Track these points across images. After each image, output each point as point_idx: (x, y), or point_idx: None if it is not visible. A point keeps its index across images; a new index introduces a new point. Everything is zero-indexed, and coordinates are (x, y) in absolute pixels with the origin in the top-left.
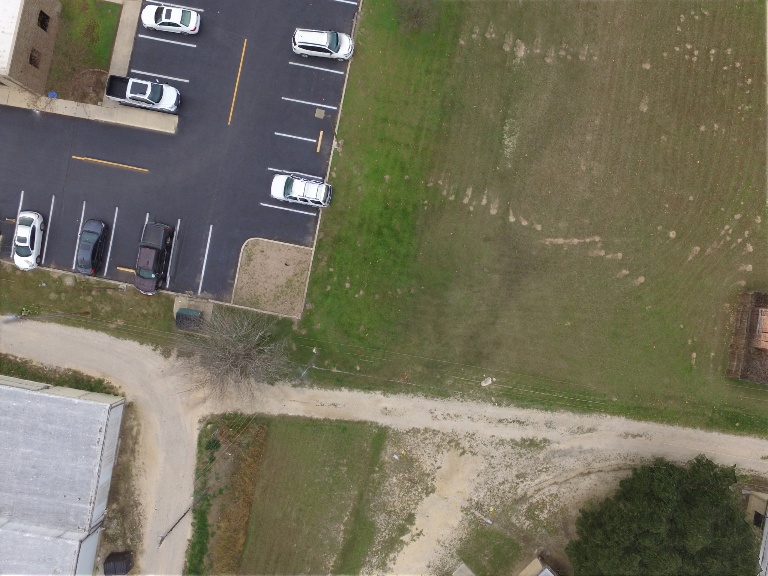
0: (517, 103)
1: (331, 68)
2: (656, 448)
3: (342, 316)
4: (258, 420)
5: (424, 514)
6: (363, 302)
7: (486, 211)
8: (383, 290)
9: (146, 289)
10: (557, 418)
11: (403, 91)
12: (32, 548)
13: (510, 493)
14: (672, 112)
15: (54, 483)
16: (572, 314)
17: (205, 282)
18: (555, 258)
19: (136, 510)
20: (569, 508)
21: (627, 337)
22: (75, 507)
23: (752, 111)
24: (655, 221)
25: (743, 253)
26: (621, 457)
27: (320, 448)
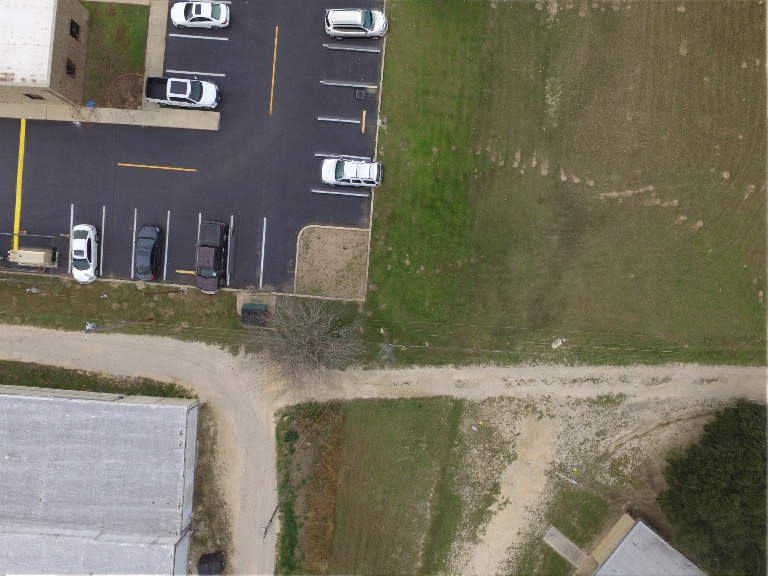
0: (556, 61)
1: (366, 48)
2: (733, 390)
3: (406, 294)
4: (333, 407)
5: (508, 482)
6: (425, 278)
7: (537, 173)
8: (443, 263)
9: (209, 288)
10: (631, 372)
11: (441, 62)
12: (128, 557)
13: (592, 451)
14: (712, 53)
15: (141, 491)
16: (635, 266)
17: (265, 275)
18: (611, 212)
19: (222, 510)
20: (652, 460)
21: (692, 283)
22: (165, 512)
23: None
24: (707, 164)
25: None
26: (699, 403)
27: (398, 428)
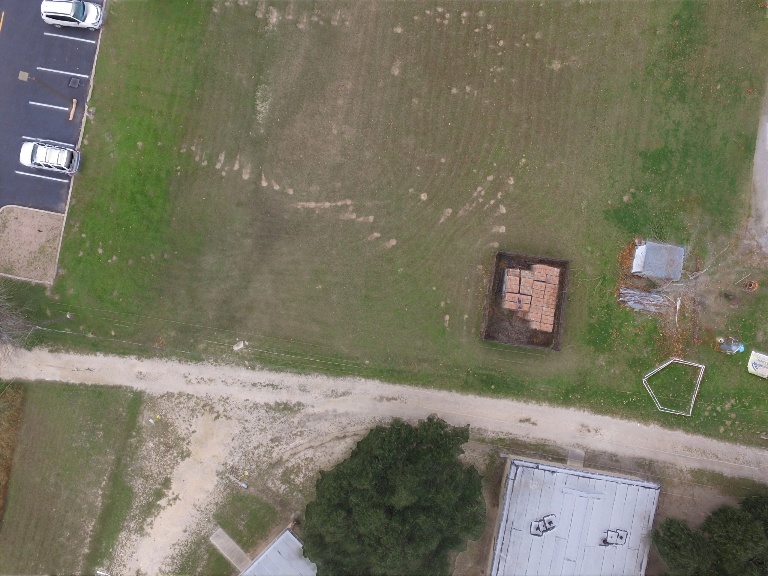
0: (269, 69)
1: (86, 38)
2: (411, 411)
3: (95, 281)
4: (15, 385)
5: (180, 478)
6: (116, 267)
7: (238, 176)
8: (136, 255)
9: None
10: (311, 381)
11: (155, 59)
12: None
13: (265, 457)
14: (423, 75)
15: None
16: (323, 277)
17: None
18: (307, 222)
19: None
20: None
21: (379, 300)
22: None
23: (504, 73)
24: (406, 183)
25: (496, 214)
26: (376, 420)
27: (76, 413)
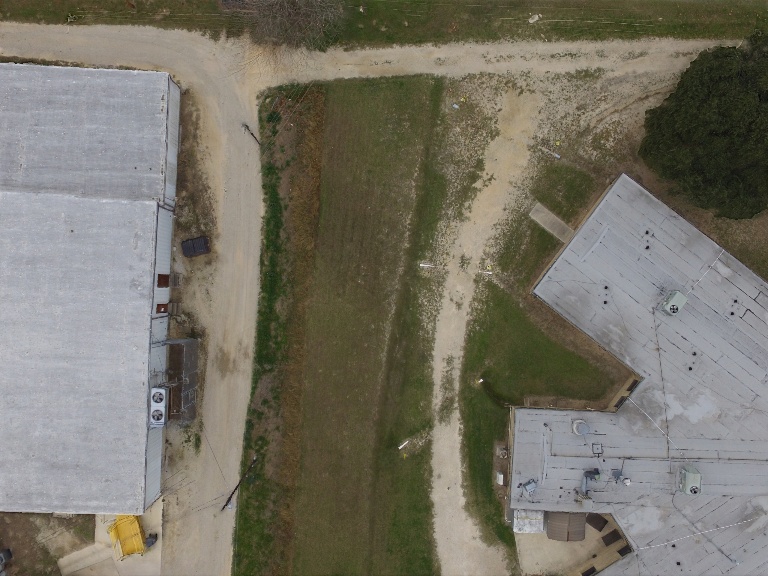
0: None
1: None
2: None
3: None
4: (315, 87)
5: (492, 158)
6: None
7: None
8: None
9: None
10: (607, 46)
11: None
12: (110, 213)
13: (573, 126)
14: None
15: (123, 156)
16: None
17: None
18: None
19: (206, 194)
20: (633, 133)
21: None
22: (147, 178)
23: None
24: None
25: None
26: (676, 76)
27: (380, 106)
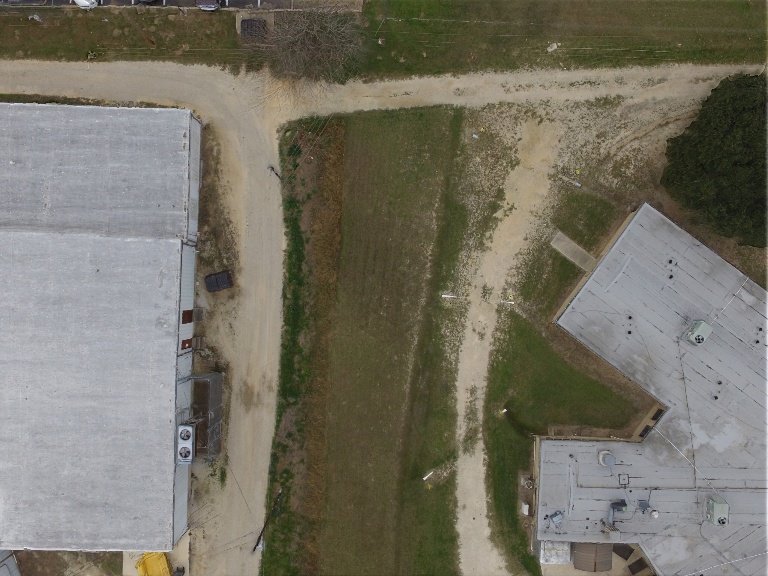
0: None
1: None
2: None
3: (401, 5)
4: (335, 120)
5: (513, 188)
6: None
7: None
8: None
9: (208, 3)
10: (626, 74)
11: None
12: (135, 252)
13: (593, 154)
14: None
15: (146, 194)
16: None
17: None
18: None
19: (228, 228)
20: (654, 160)
21: None
22: (170, 215)
23: None
24: None
25: None
26: (696, 102)
27: (400, 138)
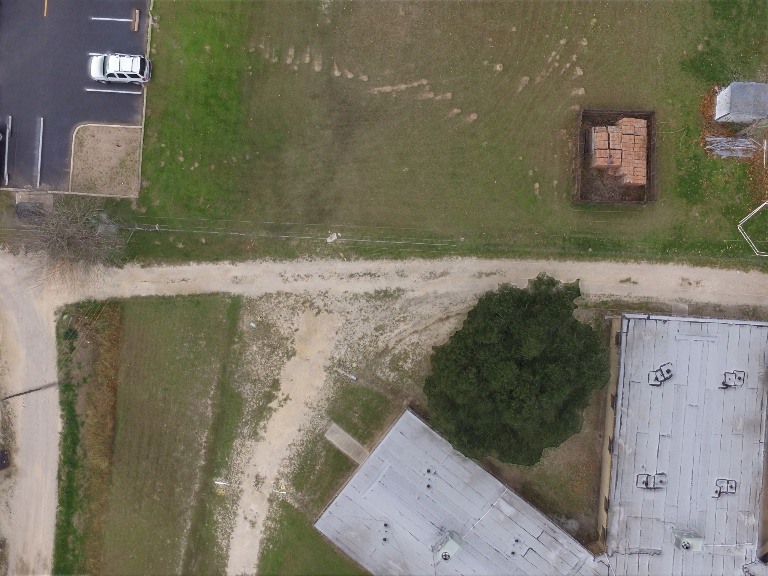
0: None
1: None
2: None
3: (180, 190)
4: (112, 305)
5: (288, 378)
6: (199, 174)
7: (311, 69)
8: (218, 160)
9: None
10: (408, 266)
11: None
12: None
13: (371, 347)
14: None
15: None
16: (408, 159)
17: (42, 175)
18: (385, 106)
19: (4, 409)
20: None
21: (467, 175)
22: None
23: None
24: (481, 56)
25: (573, 77)
26: (477, 297)
27: (176, 325)
